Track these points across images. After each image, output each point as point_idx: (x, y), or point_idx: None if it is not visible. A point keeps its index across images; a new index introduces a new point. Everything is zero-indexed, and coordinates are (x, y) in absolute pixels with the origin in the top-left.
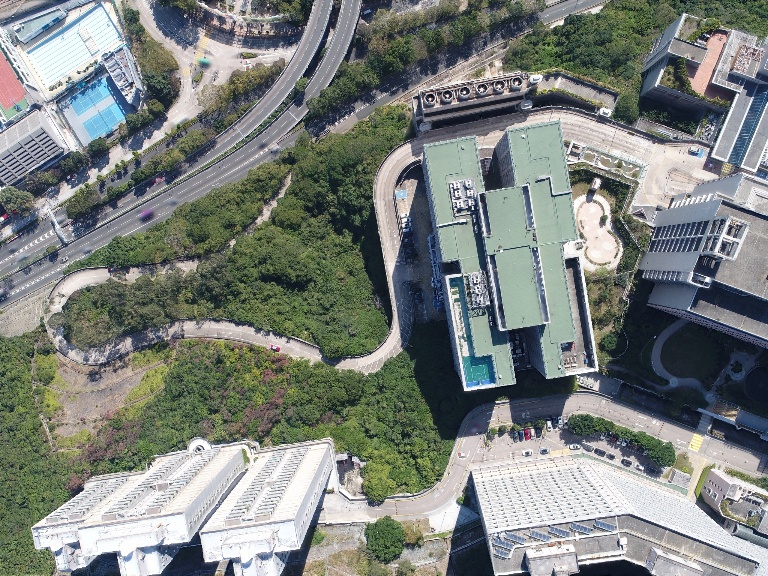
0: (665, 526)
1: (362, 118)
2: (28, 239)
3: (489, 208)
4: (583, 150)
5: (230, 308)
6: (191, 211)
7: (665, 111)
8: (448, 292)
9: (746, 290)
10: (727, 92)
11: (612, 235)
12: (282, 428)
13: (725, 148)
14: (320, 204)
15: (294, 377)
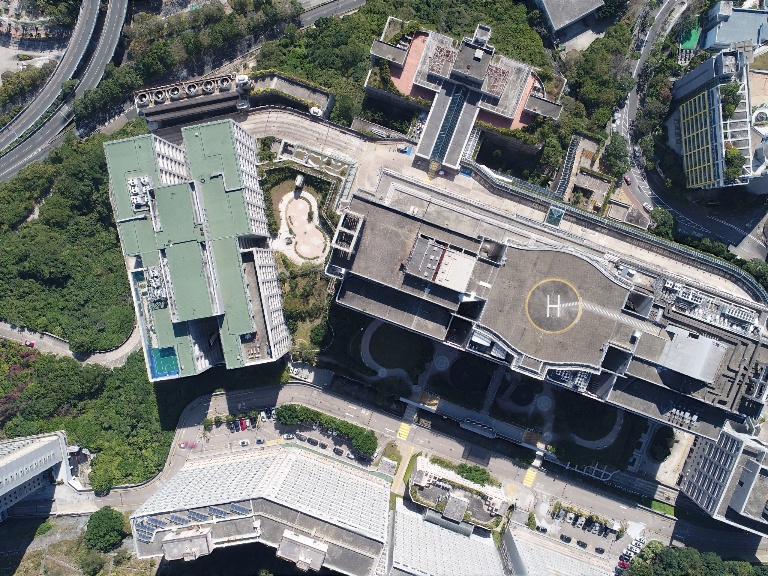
0: (295, 509)
1: (131, 118)
2: None
3: (158, 204)
4: None
5: None
6: None
7: (380, 110)
8: (131, 285)
9: (381, 281)
10: (431, 92)
11: (320, 230)
12: (16, 421)
13: (427, 146)
14: (88, 203)
15: (36, 371)
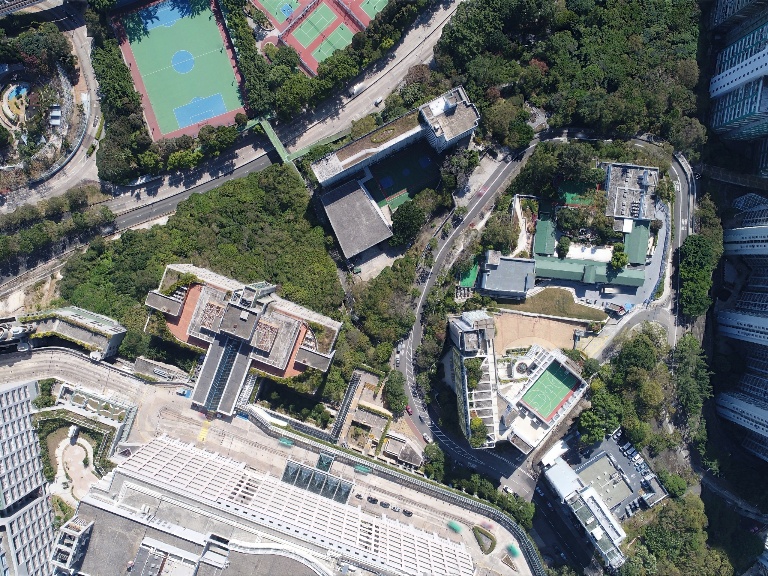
0: None
1: None
2: None
3: None
4: (73, 393)
5: None
6: None
7: (164, 349)
8: None
9: None
10: None
11: (96, 475)
12: None
13: (202, 393)
14: None
15: None
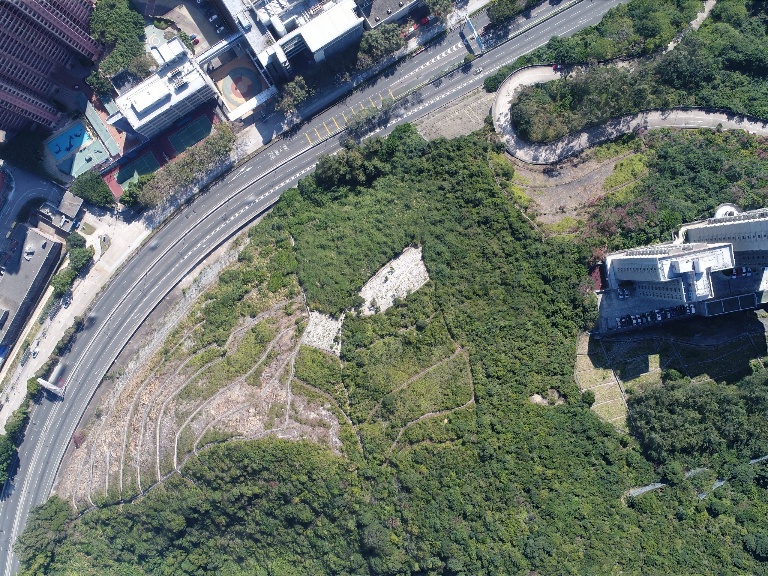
0: None
1: None
2: (435, 52)
3: None
4: None
5: (705, 93)
6: (631, 10)
7: None
8: None
9: None
10: None
11: None
12: None
13: None
14: (758, 3)
15: None
